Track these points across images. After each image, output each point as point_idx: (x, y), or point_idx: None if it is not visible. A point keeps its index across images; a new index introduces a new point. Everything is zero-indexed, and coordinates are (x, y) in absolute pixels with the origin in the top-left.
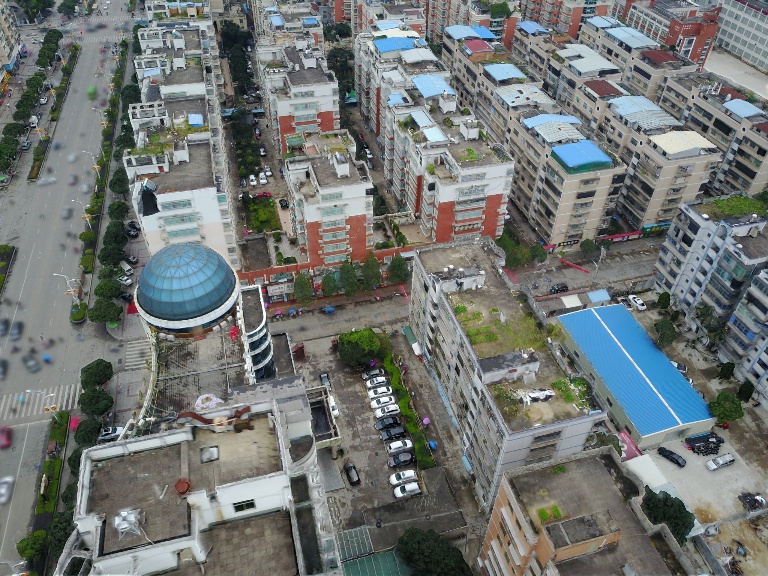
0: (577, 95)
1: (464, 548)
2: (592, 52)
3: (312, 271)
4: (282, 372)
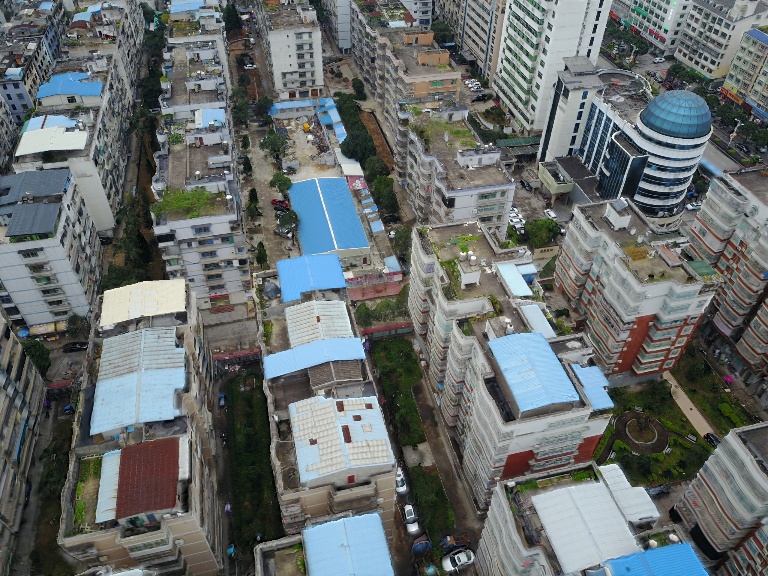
0: None
1: None
2: None
3: None
4: (593, 195)
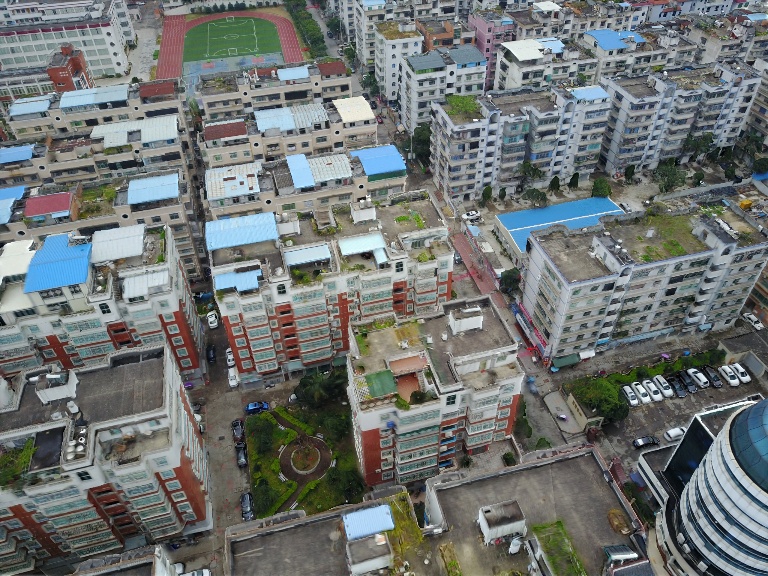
0: (213, 154)
1: None
2: (123, 124)
3: None
4: None
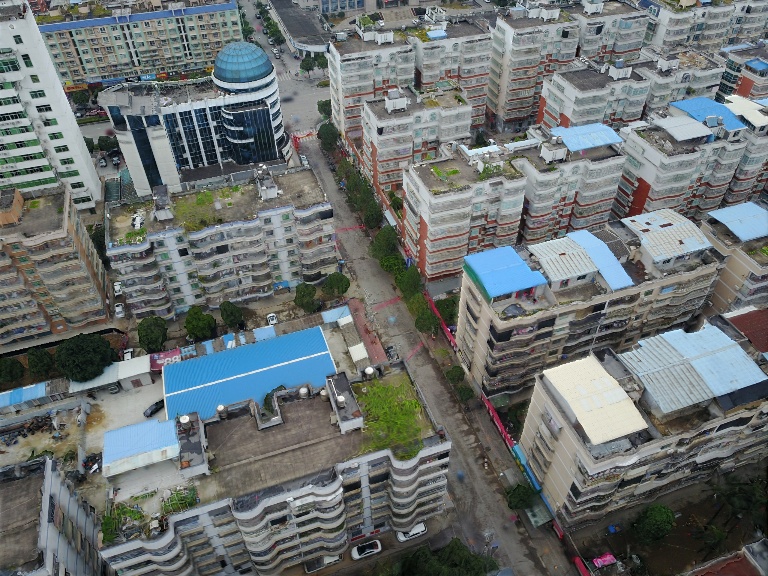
0: None
1: None
2: None
3: None
4: (250, 167)
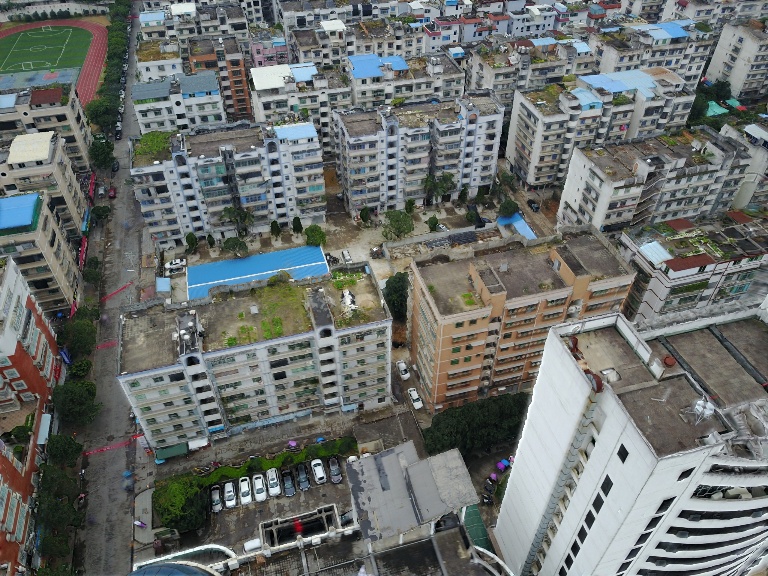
0: None
1: (421, 423)
2: None
3: (20, 567)
4: None
